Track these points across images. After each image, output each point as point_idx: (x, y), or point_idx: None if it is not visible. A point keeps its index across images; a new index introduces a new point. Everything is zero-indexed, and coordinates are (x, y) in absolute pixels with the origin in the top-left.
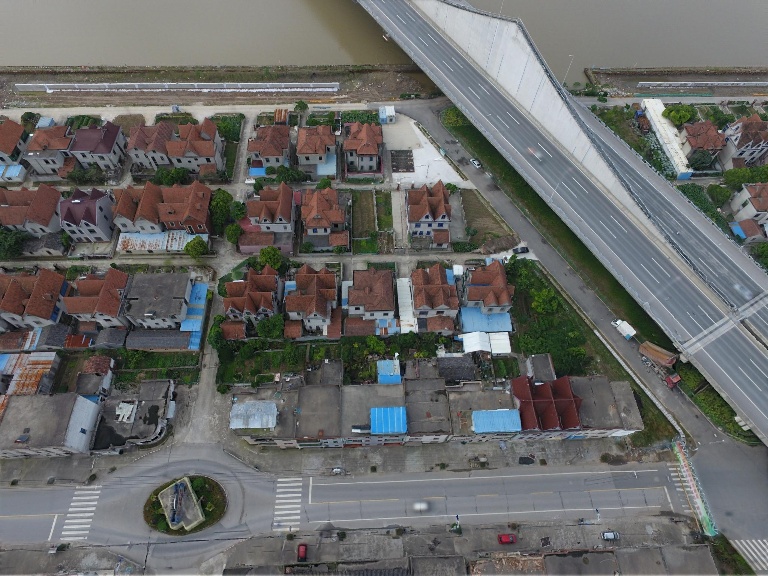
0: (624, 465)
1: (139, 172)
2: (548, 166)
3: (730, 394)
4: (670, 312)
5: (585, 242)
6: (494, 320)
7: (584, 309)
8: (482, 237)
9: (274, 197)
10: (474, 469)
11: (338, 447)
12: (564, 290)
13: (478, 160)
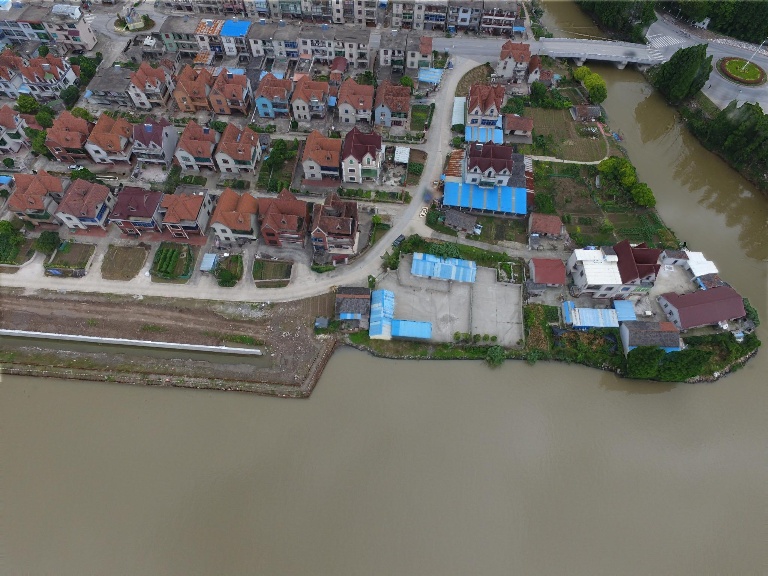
0: None
1: None
2: None
3: None
4: None
5: None
6: None
7: None
8: None
9: None
10: None
11: None
12: None
13: None
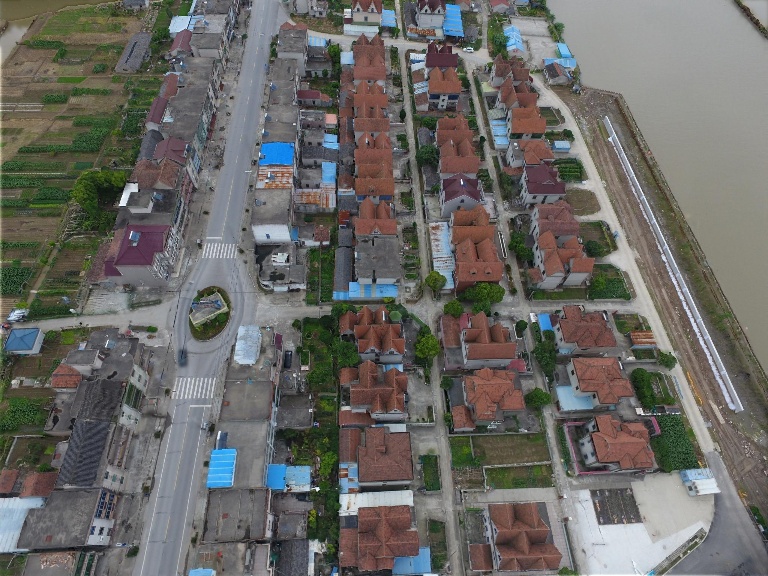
0: None
1: (523, 222)
2: None
3: None
4: None
5: None
6: None
7: None
8: None
9: (498, 339)
10: None
11: None
12: None
13: None
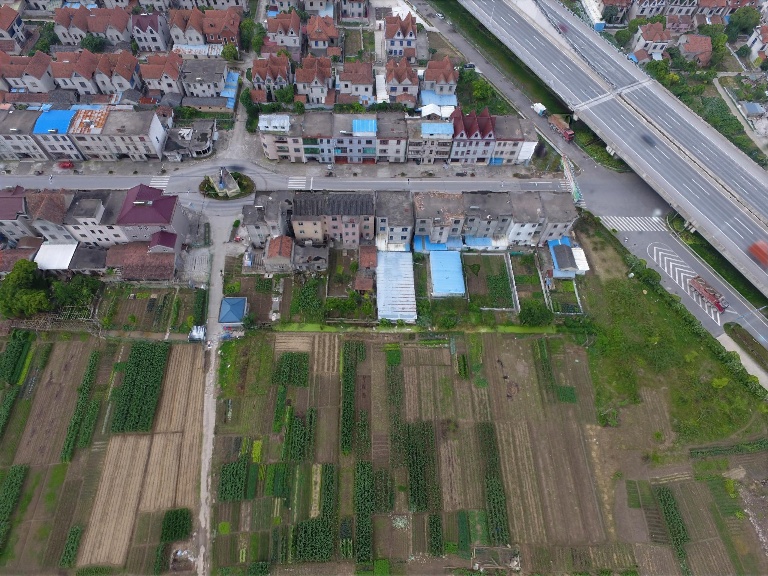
0: (529, 179)
1: None
2: (491, 7)
3: (603, 131)
4: (568, 89)
5: (513, 50)
6: (445, 99)
7: (512, 100)
8: (441, 59)
9: None
10: (424, 177)
11: (331, 163)
12: (499, 89)
13: (442, 13)
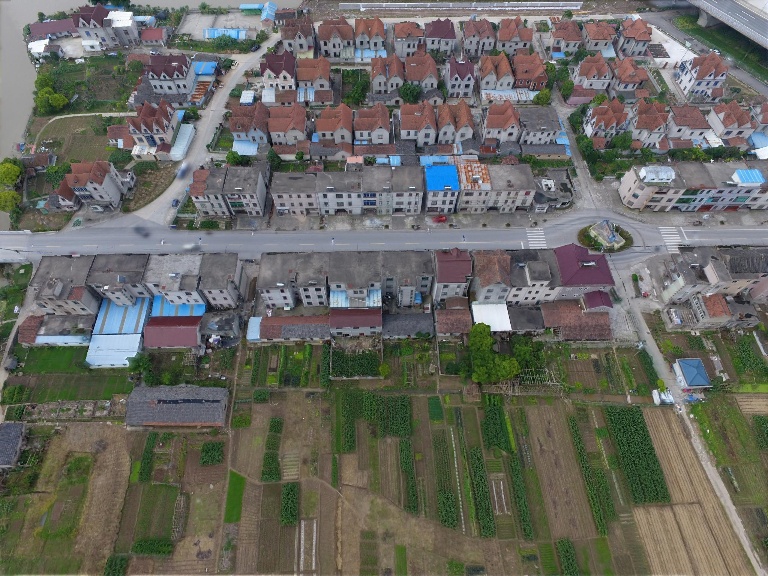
0: None
1: None
2: None
3: None
4: None
5: None
6: None
7: None
8: (739, 97)
9: None
10: None
11: (692, 211)
12: None
13: (717, 49)
